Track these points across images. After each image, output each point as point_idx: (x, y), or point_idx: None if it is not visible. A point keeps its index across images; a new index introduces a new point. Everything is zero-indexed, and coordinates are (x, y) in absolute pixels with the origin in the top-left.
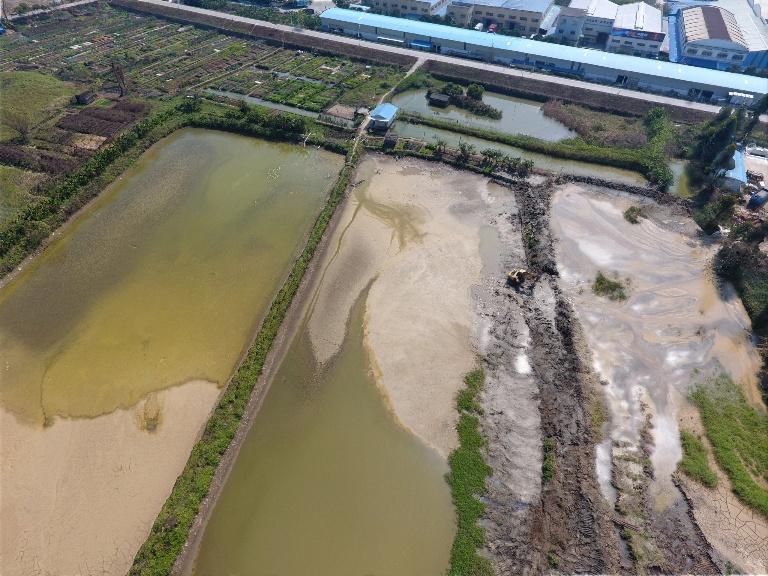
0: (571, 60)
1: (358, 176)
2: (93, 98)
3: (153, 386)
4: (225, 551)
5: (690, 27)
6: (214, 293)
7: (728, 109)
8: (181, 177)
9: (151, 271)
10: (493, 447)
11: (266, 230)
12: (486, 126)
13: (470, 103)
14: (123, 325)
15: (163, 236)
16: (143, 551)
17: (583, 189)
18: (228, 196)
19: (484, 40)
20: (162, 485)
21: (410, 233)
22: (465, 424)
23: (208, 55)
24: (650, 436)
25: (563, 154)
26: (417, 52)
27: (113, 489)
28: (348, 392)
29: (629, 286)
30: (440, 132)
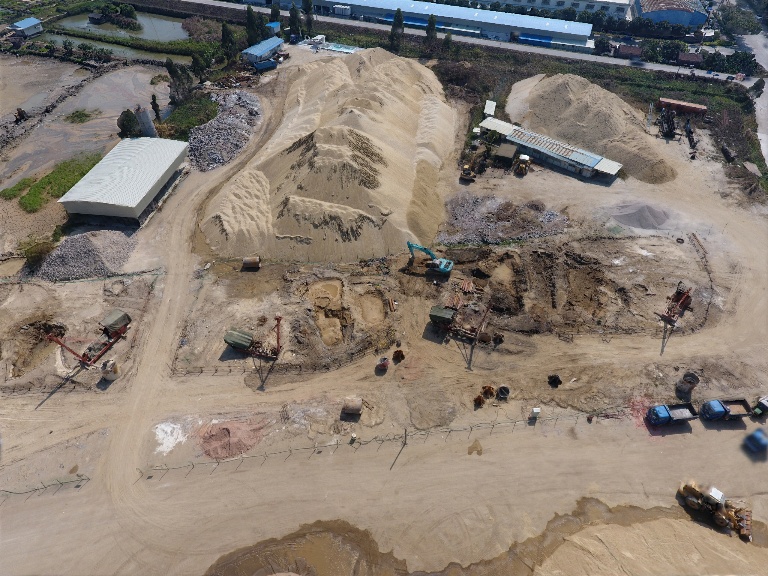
0: None
1: None
2: None
3: None
4: None
5: None
6: None
7: (273, 6)
8: None
9: None
10: None
11: None
12: (109, 32)
13: None
14: None
15: None
16: None
17: (143, 68)
18: None
19: None
20: None
21: None
22: None
23: None
24: (1, 181)
25: (157, 49)
26: None
27: None
28: None
29: (96, 116)
30: (79, 40)
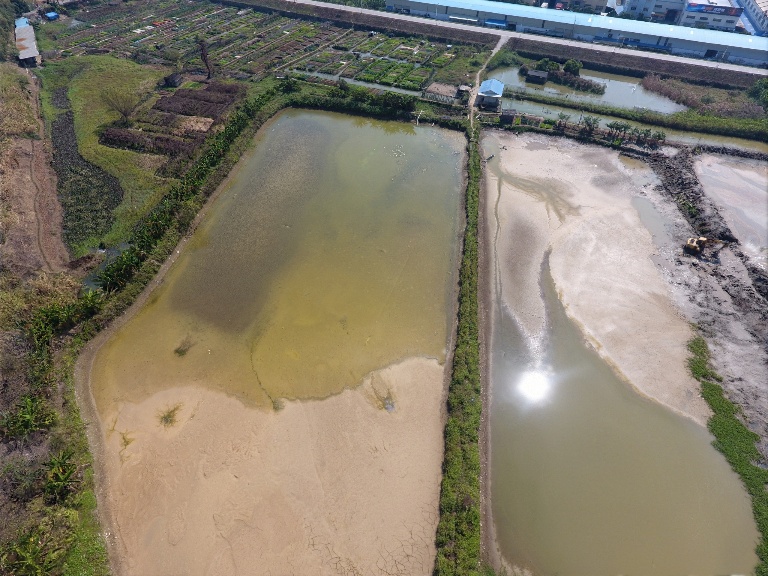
0: (658, 35)
1: (485, 152)
2: (181, 80)
3: (371, 365)
4: (522, 529)
5: (763, 2)
6: (392, 270)
7: None
8: (305, 156)
9: (316, 250)
10: (748, 413)
11: (416, 207)
12: (598, 100)
13: (569, 79)
14: (311, 305)
15: (312, 215)
16: (448, 532)
17: (720, 159)
18: (361, 174)
19: (563, 17)
20: (427, 465)
21: (564, 206)
22: (710, 392)
23: (279, 37)
24: None
25: (685, 126)
26: (497, 30)
27: (378, 471)
28: (574, 364)
29: None
30: (547, 108)
